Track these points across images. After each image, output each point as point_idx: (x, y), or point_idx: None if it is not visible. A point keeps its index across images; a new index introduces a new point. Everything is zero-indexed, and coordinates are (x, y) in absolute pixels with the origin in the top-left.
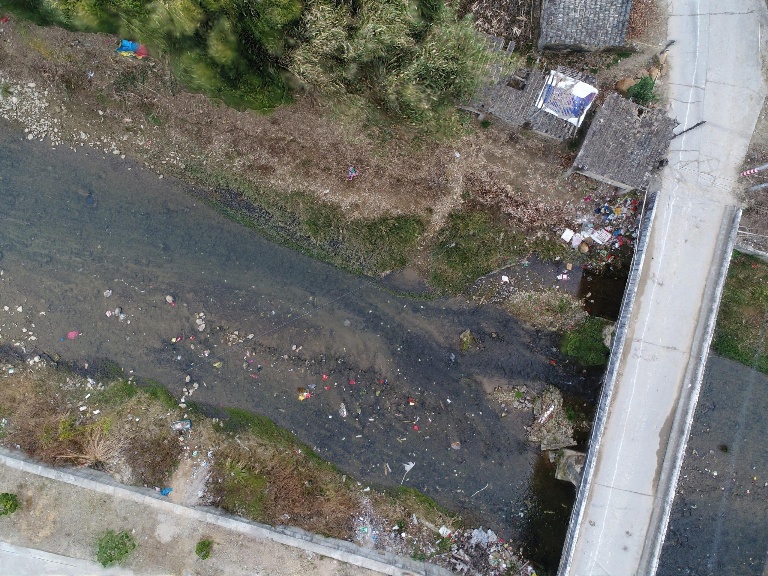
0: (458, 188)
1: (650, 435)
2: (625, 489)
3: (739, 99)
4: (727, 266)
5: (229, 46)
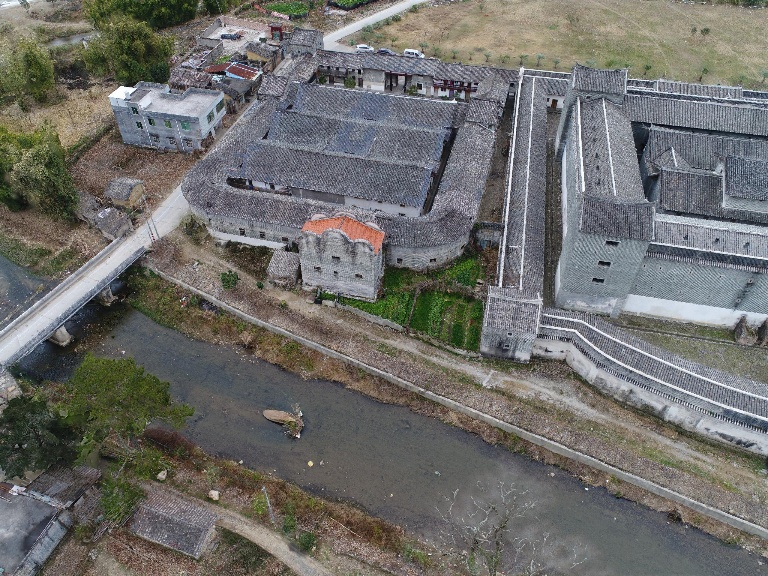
0: (70, 244)
1: (70, 303)
2: (48, 317)
3: (168, 226)
4: (128, 258)
5: (2, 172)
